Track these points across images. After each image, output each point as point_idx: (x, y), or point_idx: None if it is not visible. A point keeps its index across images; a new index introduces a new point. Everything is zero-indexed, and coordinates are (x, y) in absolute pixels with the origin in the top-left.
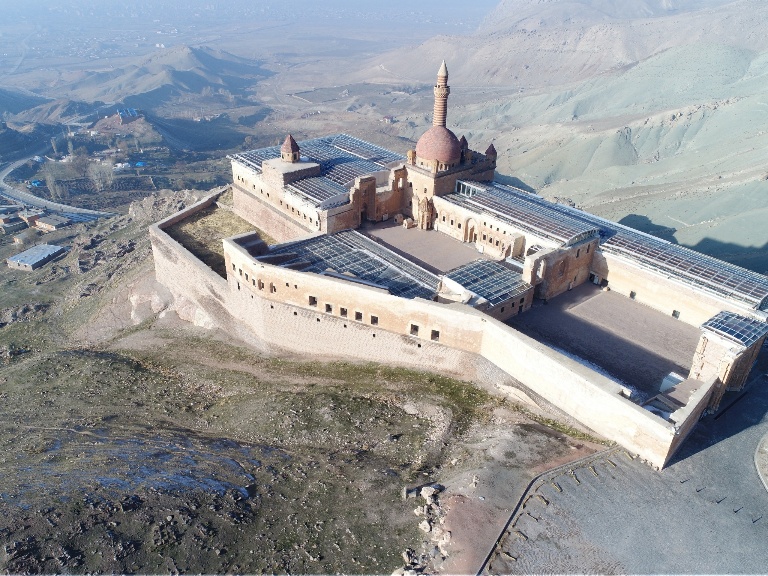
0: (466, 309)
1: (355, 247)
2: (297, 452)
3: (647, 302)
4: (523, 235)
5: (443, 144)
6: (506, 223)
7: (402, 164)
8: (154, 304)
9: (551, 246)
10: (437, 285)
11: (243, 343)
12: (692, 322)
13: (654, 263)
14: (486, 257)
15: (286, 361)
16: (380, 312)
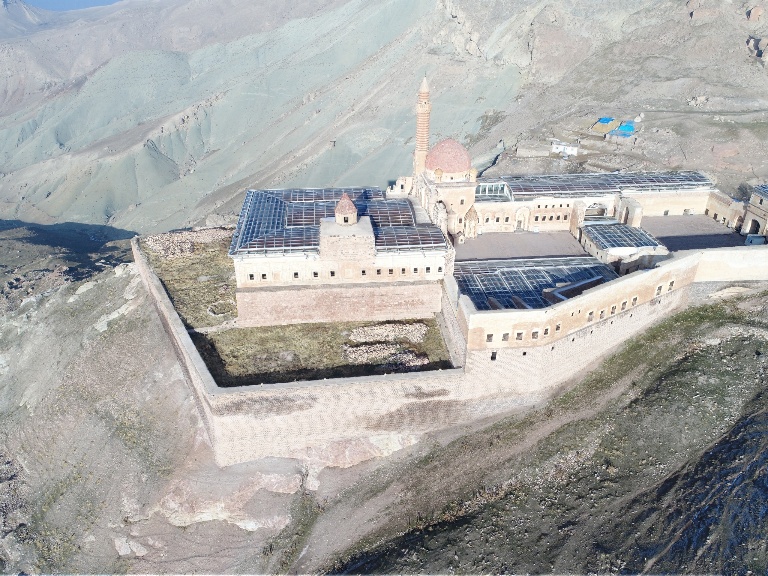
0: (686, 253)
1: (490, 271)
2: (766, 406)
3: (646, 214)
4: (582, 200)
5: (466, 154)
6: (563, 197)
7: (433, 185)
8: (280, 486)
9: (608, 199)
10: (592, 261)
11: (492, 418)
12: (677, 213)
13: (647, 186)
14: (545, 234)
15: (567, 393)
16: (640, 291)
